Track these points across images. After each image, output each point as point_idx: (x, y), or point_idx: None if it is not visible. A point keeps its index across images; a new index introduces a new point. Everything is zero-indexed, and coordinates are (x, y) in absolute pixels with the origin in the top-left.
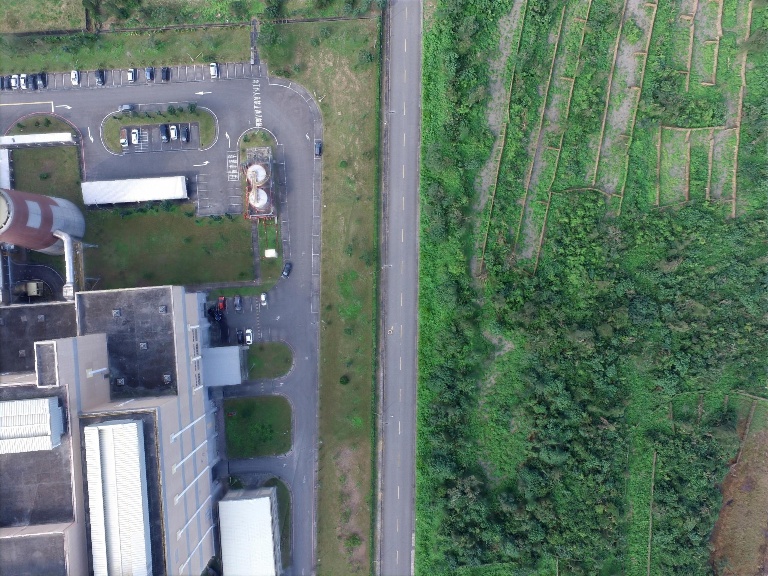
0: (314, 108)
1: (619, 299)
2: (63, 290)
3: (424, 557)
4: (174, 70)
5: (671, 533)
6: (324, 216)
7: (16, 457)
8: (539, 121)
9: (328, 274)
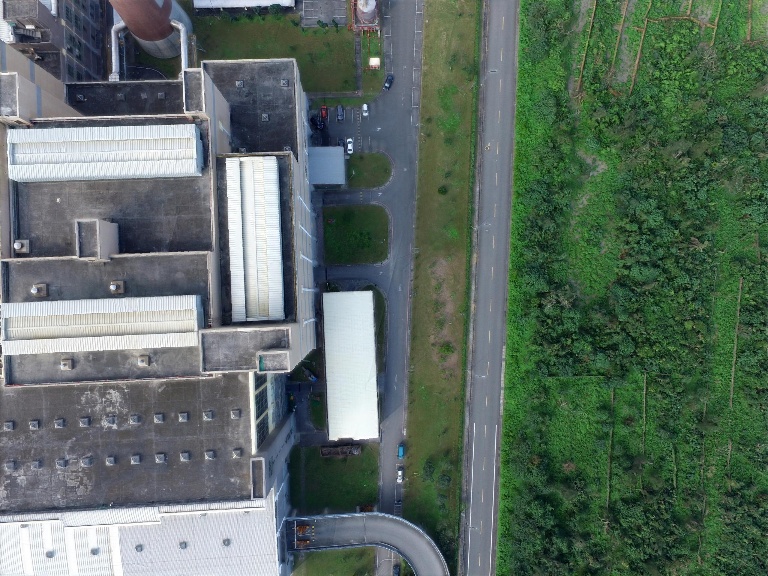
0: None
1: (711, 126)
2: (179, 77)
3: (515, 368)
4: None
5: (756, 355)
6: (426, 31)
7: (157, 189)
8: None
9: (428, 88)
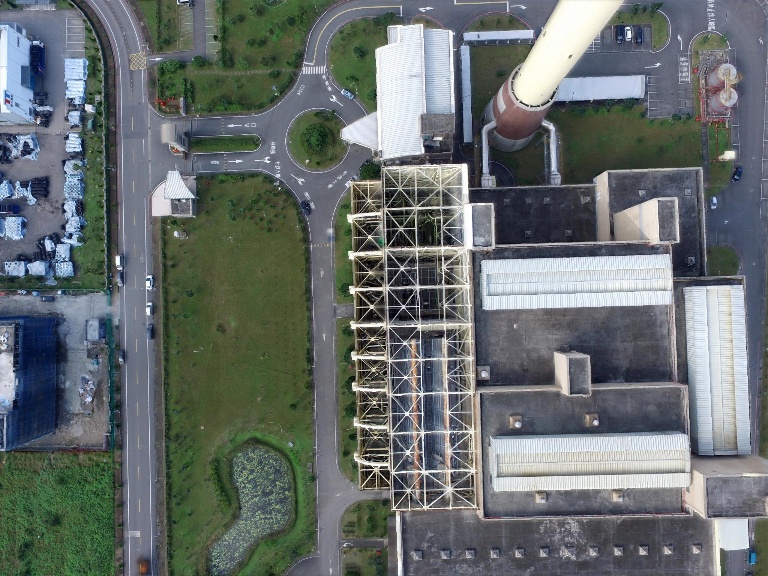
0: None
1: None
2: (551, 178)
3: None
4: None
5: None
6: None
7: (613, 315)
8: None
9: None
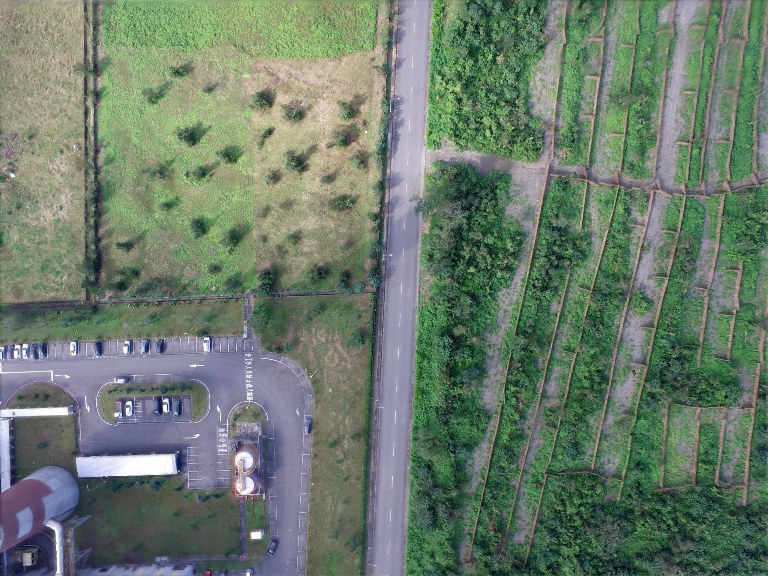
0: (305, 383)
1: None
2: None
3: None
4: (169, 342)
5: None
6: (312, 494)
7: None
8: (537, 398)
9: (314, 553)
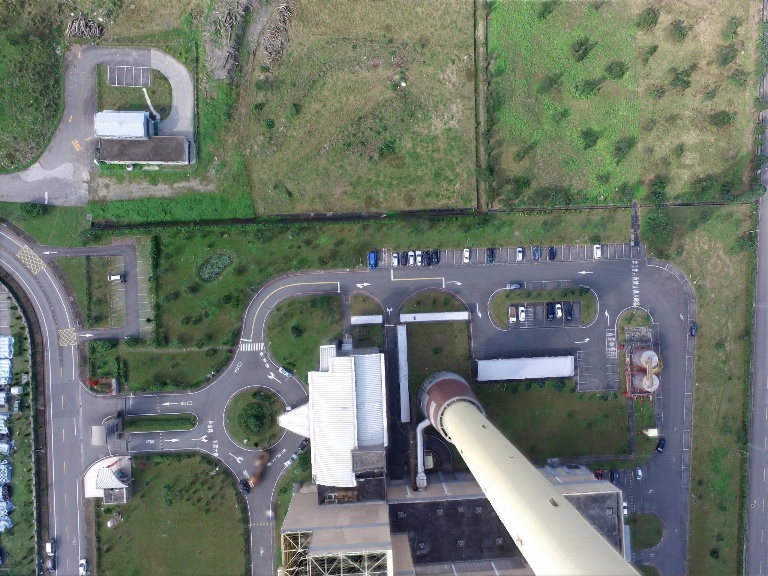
0: (688, 289)
1: None
2: None
3: None
4: (558, 249)
5: None
6: (696, 394)
7: None
8: None
9: (698, 450)
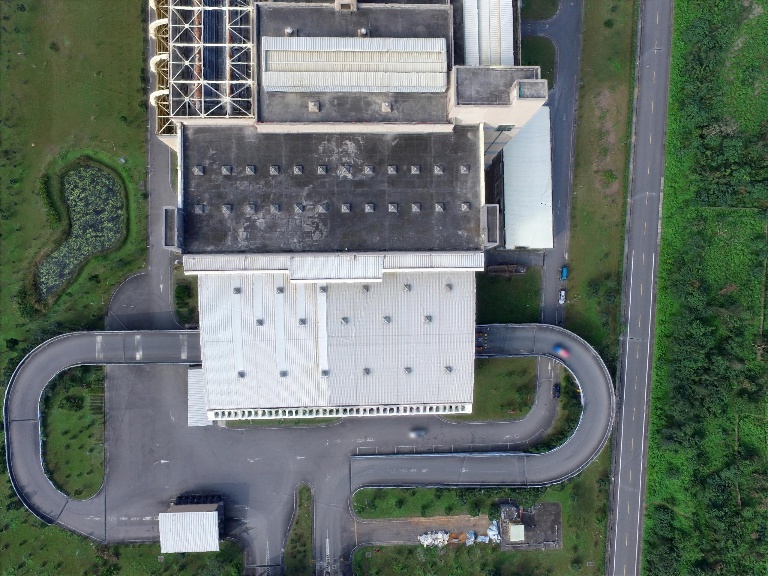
0: None
1: None
2: None
3: (673, 198)
4: None
5: None
6: None
7: None
8: None
9: None
